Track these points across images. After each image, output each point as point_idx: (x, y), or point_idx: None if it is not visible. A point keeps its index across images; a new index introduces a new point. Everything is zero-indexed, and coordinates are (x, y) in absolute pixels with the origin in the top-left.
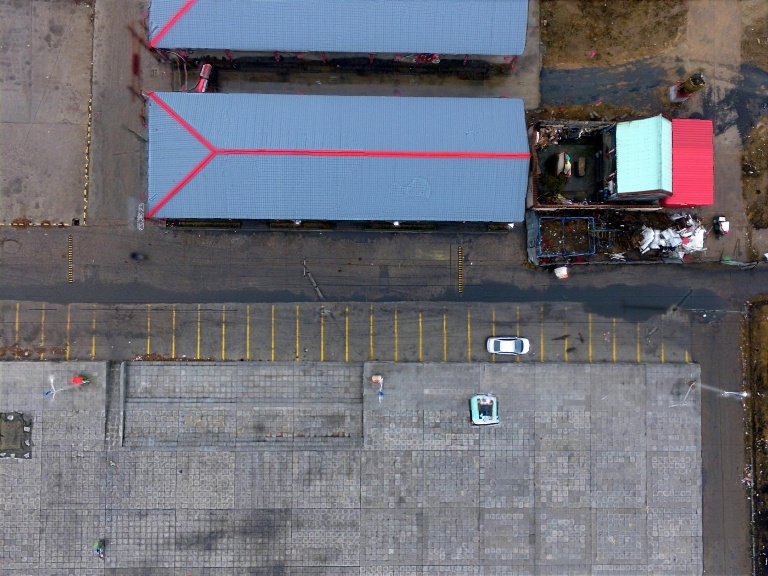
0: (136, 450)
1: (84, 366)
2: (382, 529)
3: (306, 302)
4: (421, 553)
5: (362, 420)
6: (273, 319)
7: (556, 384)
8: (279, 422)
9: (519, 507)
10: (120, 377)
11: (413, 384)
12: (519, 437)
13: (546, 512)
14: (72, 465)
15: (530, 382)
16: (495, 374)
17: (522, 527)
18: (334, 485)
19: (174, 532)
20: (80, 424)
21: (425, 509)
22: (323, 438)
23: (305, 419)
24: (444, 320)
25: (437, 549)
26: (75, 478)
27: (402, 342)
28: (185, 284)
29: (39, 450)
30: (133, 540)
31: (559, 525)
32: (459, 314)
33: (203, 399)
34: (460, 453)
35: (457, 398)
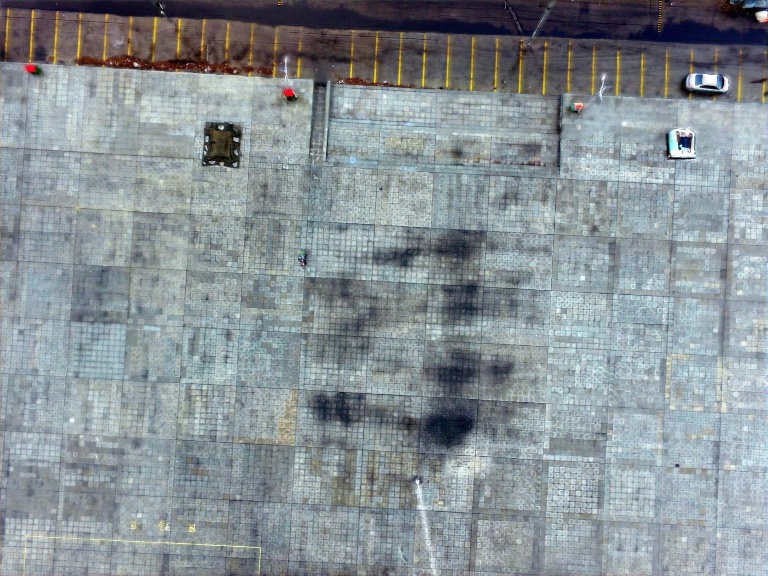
0: (339, 166)
1: (292, 82)
2: (575, 256)
3: (505, 36)
4: (612, 281)
5: (558, 150)
6: (473, 50)
7: (754, 123)
8: (476, 148)
9: (712, 242)
10: (326, 95)
11: (611, 116)
12: (715, 173)
13: (739, 249)
14: (277, 177)
15: (728, 120)
16: (693, 110)
17: (714, 262)
18: (529, 210)
19: (372, 247)
20: (286, 138)
21: (618, 239)
22: (519, 166)
23: (502, 147)
24: (642, 59)
25: (628, 278)
26: (280, 189)
27: (599, 79)
28: (388, 12)
29: (246, 160)
30: (333, 252)
31: (751, 262)
32: (657, 54)
33: (403, 123)
34: (655, 186)
35: (654, 132)
